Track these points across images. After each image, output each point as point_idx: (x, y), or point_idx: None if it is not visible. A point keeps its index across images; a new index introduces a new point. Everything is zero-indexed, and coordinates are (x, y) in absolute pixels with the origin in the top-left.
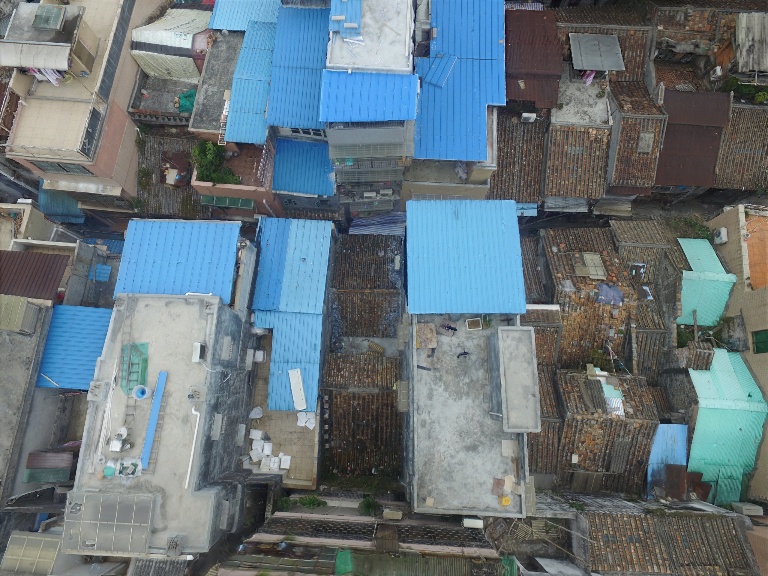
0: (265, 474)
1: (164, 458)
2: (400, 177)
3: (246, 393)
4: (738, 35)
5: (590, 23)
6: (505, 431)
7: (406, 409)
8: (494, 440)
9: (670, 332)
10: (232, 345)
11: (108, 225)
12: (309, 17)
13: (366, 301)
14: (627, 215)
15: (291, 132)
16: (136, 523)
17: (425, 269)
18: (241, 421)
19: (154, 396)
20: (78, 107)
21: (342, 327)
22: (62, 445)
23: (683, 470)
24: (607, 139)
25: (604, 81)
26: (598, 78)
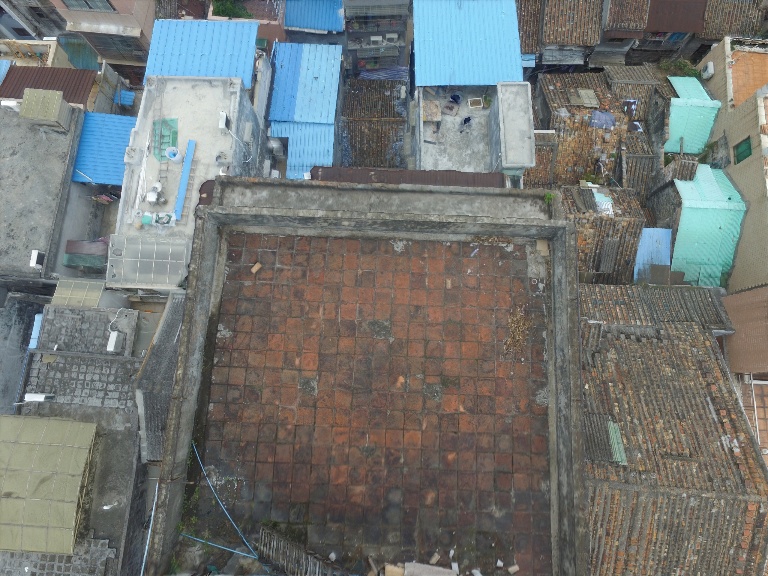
0: None
1: None
2: (405, 11)
3: None
4: None
5: None
6: (503, 166)
7: None
8: None
9: (658, 156)
10: (252, 141)
11: None
12: None
13: (374, 130)
14: None
15: None
16: (173, 260)
17: (431, 50)
18: None
19: (185, 159)
20: None
21: (351, 156)
22: (96, 239)
23: (667, 269)
24: None
25: None
26: None
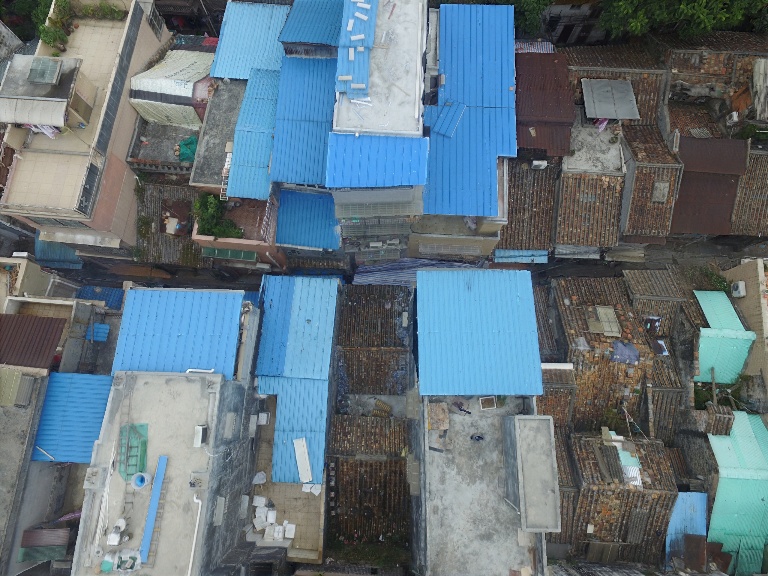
0: (269, 547)
1: (164, 550)
2: (408, 230)
3: (249, 460)
4: (756, 81)
5: (602, 66)
6: (523, 531)
7: (417, 492)
8: (510, 528)
9: (687, 391)
10: (235, 417)
11: (107, 268)
12: (314, 67)
13: (373, 359)
14: (640, 261)
15: (295, 185)
16: None
17: (437, 346)
18: (244, 491)
19: (154, 483)
20: (75, 160)
21: (348, 385)
22: (58, 519)
23: (703, 540)
24: (620, 187)
25: (617, 126)
26: (611, 123)
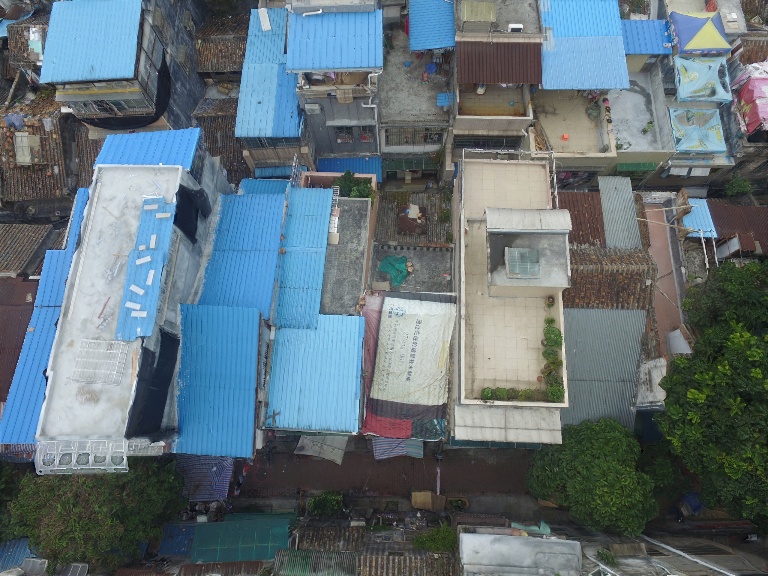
0: None
1: None
2: None
3: None
4: None
5: None
6: None
7: None
8: None
9: None
10: None
11: None
12: (232, 306)
13: None
14: None
15: None
16: None
17: (125, 26)
18: None
19: None
20: None
21: None
22: None
23: (7, 17)
24: None
25: None
26: None
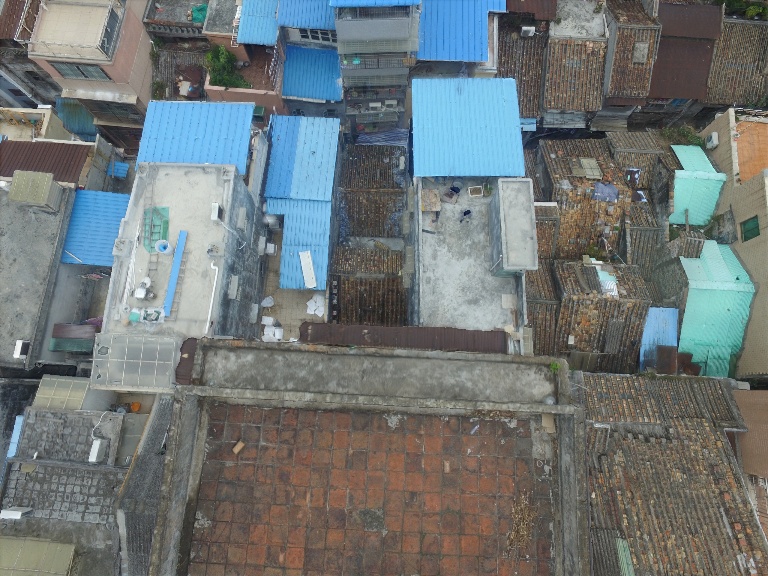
0: None
1: (185, 308)
2: (405, 82)
3: (258, 279)
4: None
5: None
6: (505, 268)
7: (412, 270)
8: (494, 294)
9: (663, 229)
10: (246, 222)
11: None
12: None
13: (372, 201)
14: (623, 131)
15: (300, 37)
16: (160, 361)
17: (430, 138)
18: (254, 302)
19: (175, 252)
20: (96, 12)
21: (349, 227)
22: (85, 320)
23: (674, 351)
24: (603, 52)
25: None
26: None
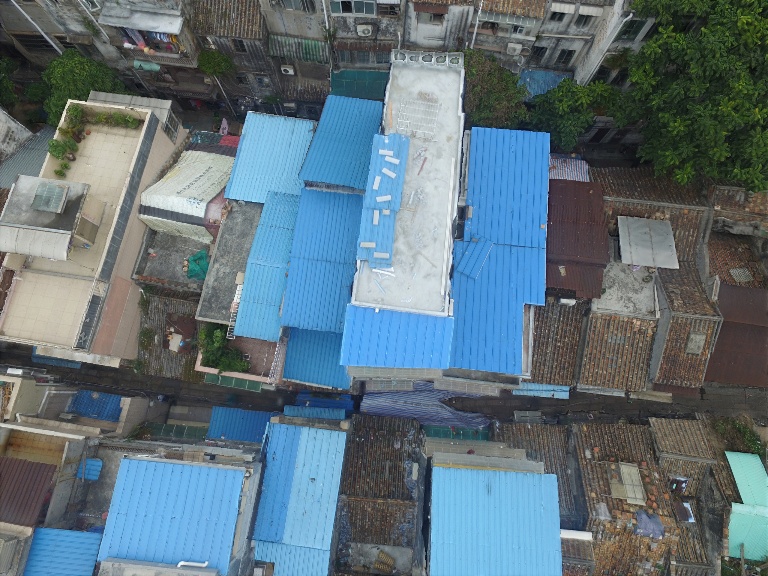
0: None
1: None
2: None
3: None
4: None
5: (640, 196)
6: None
7: None
8: None
9: (713, 569)
10: None
11: None
12: (334, 203)
13: (378, 509)
14: (667, 402)
15: None
16: None
17: (450, 561)
18: None
19: None
20: (77, 284)
21: (350, 533)
22: None
23: None
24: (652, 331)
25: None
26: None
